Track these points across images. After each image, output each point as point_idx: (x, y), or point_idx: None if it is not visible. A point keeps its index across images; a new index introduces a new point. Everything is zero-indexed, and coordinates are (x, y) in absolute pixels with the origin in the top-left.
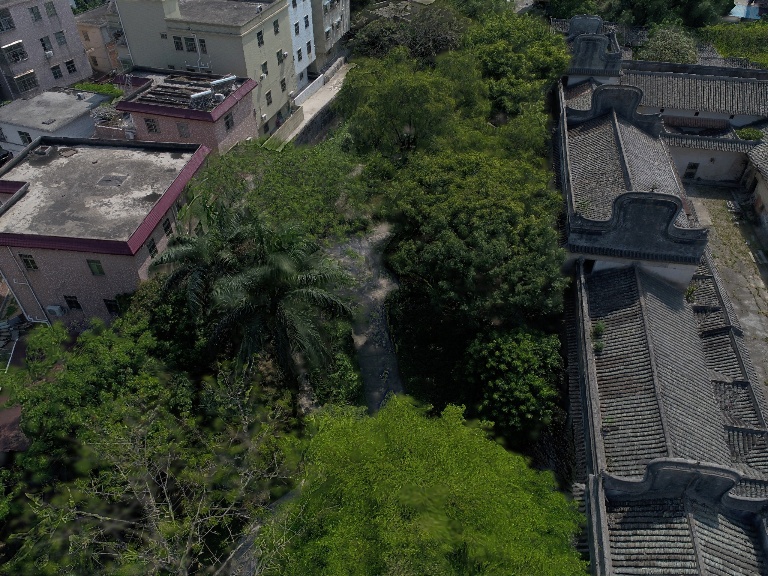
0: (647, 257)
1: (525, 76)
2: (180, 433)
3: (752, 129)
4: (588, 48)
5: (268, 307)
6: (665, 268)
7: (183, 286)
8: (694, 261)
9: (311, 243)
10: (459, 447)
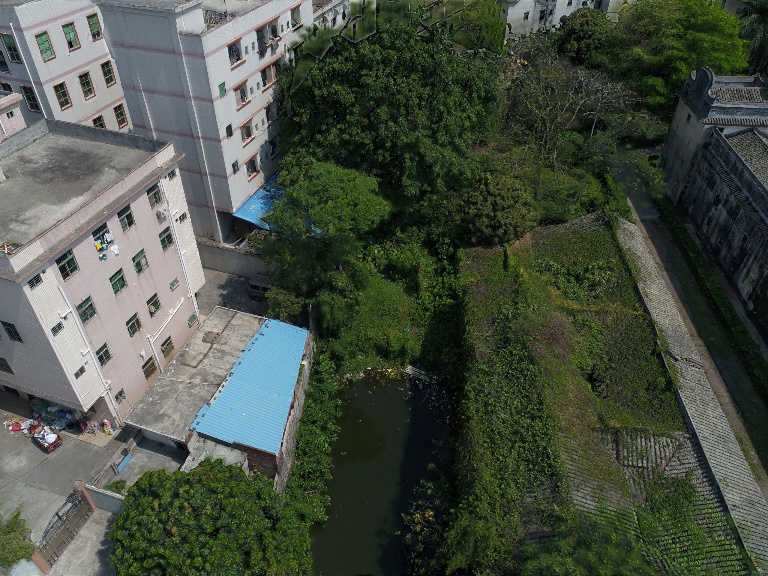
0: None
1: None
2: None
3: None
4: None
5: (757, 24)
6: None
7: (744, 8)
8: None
9: None
10: None
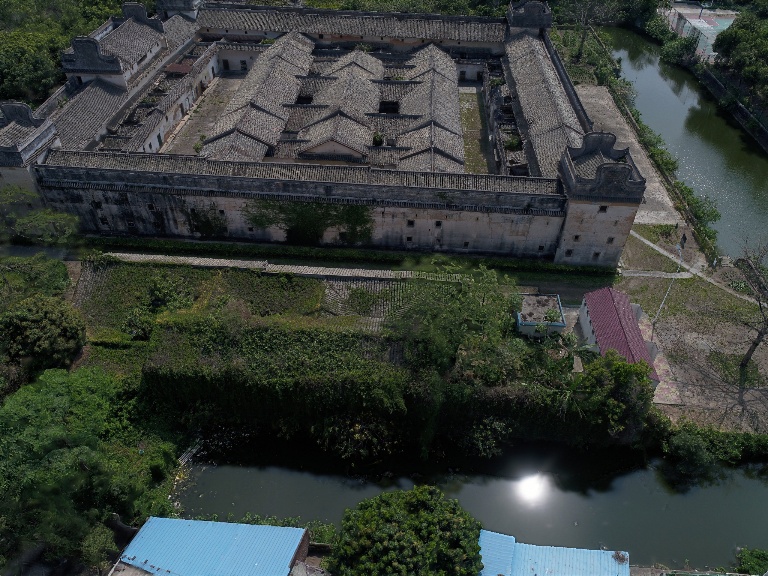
0: (98, 71)
1: (113, 6)
2: None
3: (270, 39)
4: None
5: None
6: (111, 78)
7: None
8: (118, 72)
9: None
10: None
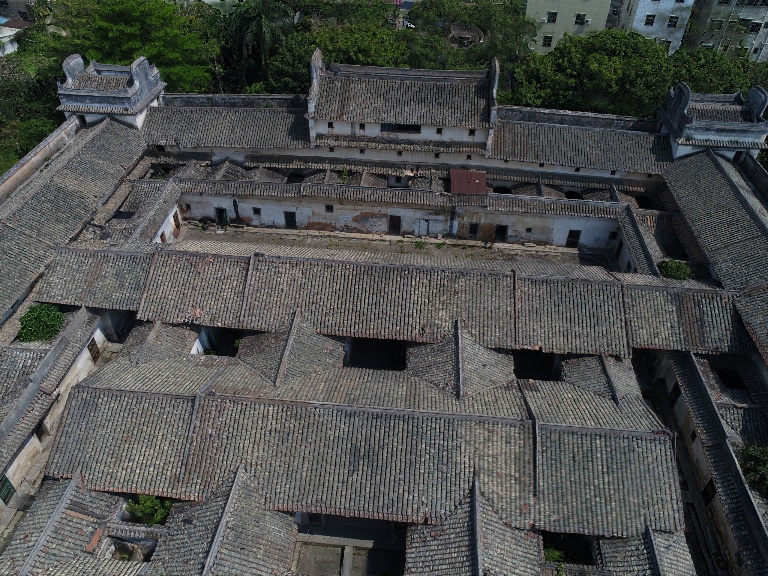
0: None
1: None
2: (233, 48)
3: None
4: (678, 99)
5: None
6: None
7: None
8: None
9: (286, 7)
10: (145, 8)
